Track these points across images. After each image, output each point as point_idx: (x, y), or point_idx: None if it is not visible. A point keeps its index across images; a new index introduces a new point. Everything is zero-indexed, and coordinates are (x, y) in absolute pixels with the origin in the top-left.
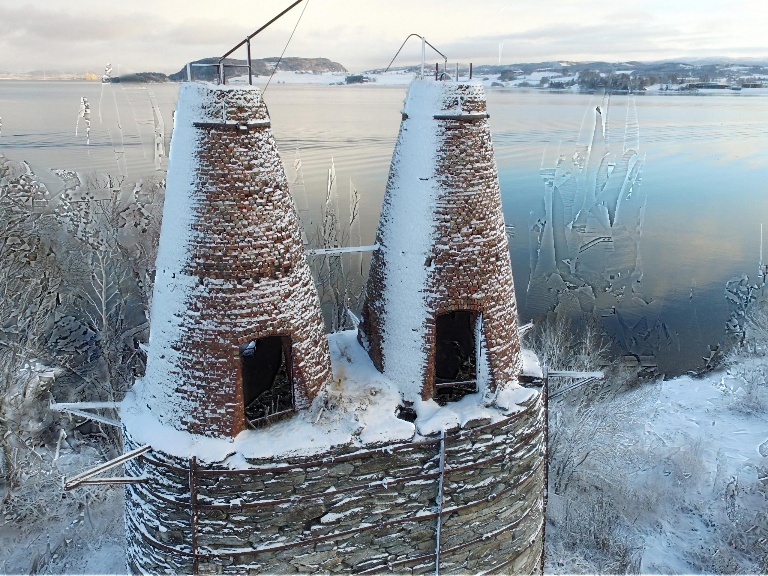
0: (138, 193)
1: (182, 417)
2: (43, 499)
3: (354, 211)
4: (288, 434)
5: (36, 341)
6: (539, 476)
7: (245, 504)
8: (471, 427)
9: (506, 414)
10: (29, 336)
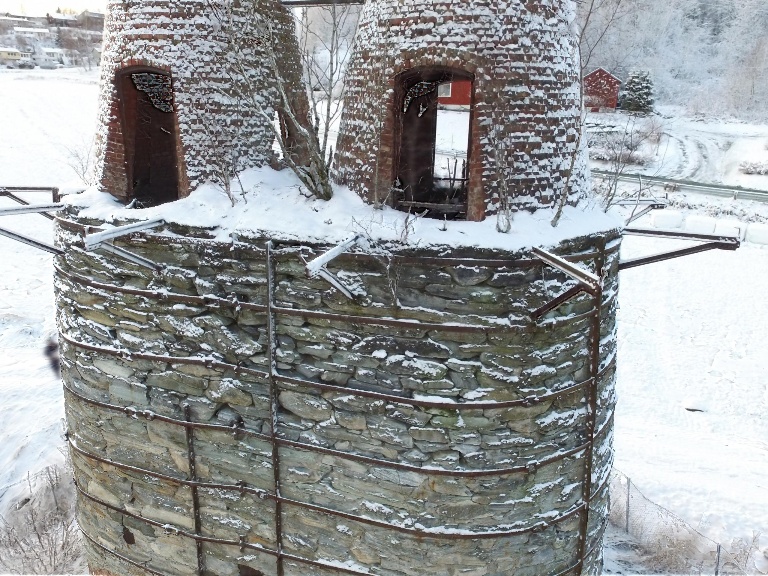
0: None
1: None
2: None
3: None
4: None
5: None
6: None
7: None
8: None
9: None
10: None
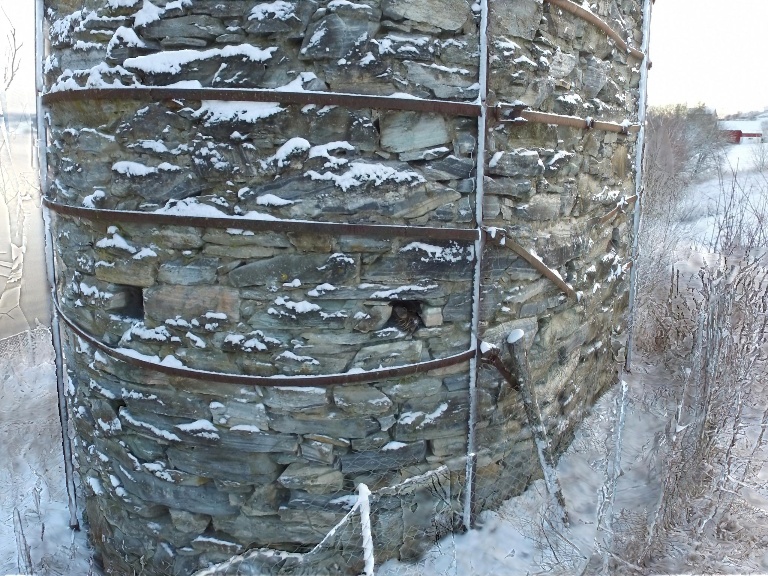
0: None
1: None
2: None
3: (13, 63)
4: None
5: None
6: None
7: None
8: None
9: None
10: None
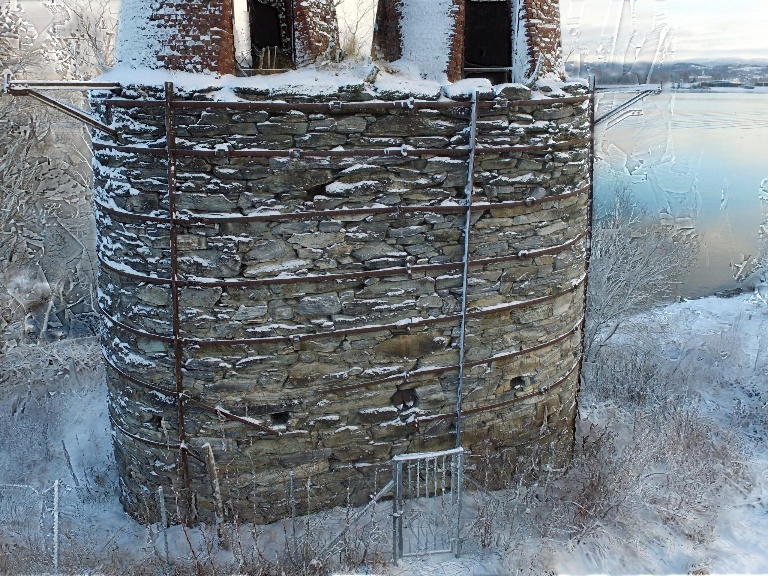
0: None
1: (158, 51)
2: (28, 363)
3: None
4: (287, 74)
5: (24, 204)
6: (583, 208)
7: (233, 151)
8: (508, 99)
9: (549, 94)
10: (15, 190)
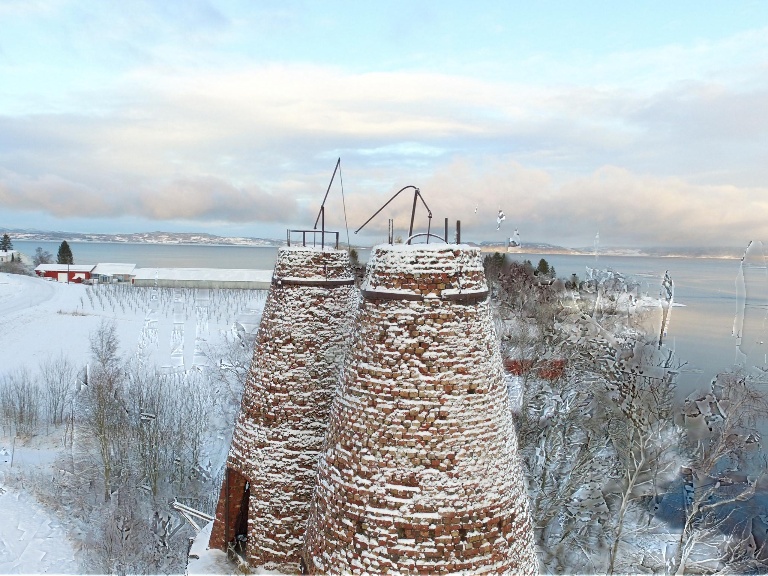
0: (714, 383)
1: None
2: None
3: None
4: (209, 573)
5: None
6: None
7: None
8: None
9: None
10: None
